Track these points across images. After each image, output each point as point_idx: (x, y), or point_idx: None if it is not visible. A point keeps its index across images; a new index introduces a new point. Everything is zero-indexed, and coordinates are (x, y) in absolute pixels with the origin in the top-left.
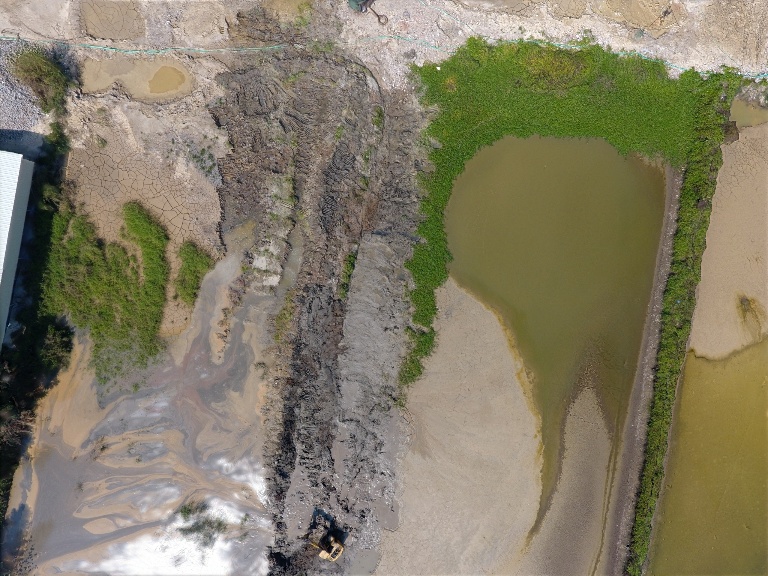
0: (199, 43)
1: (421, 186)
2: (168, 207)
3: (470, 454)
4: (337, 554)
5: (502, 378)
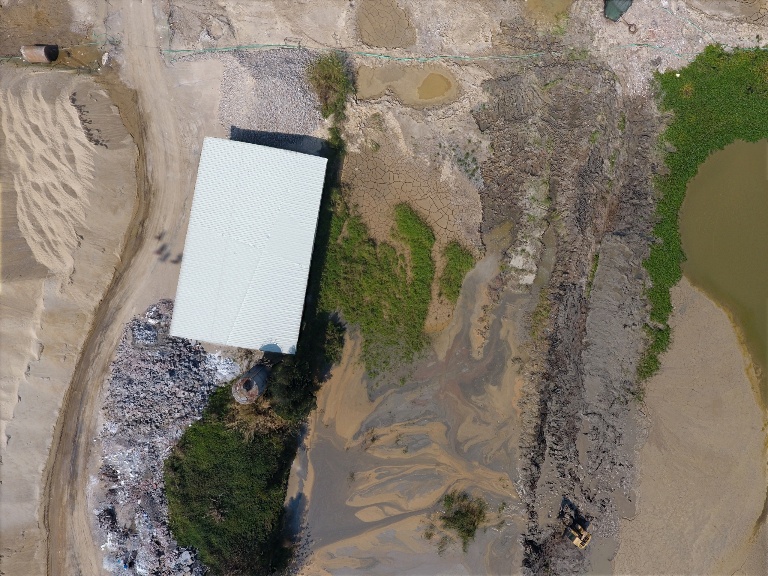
0: (465, 51)
1: (657, 188)
2: (434, 208)
3: (702, 446)
4: (586, 542)
5: (732, 373)
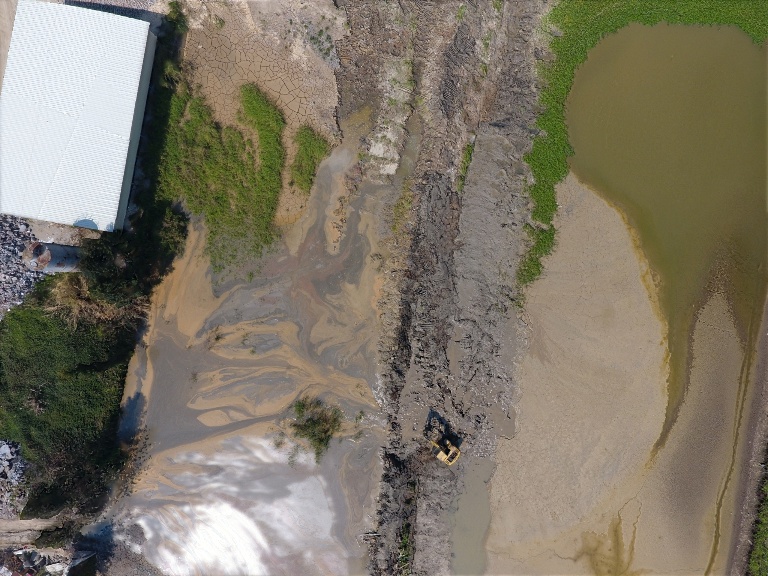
0: None
1: (541, 76)
2: (285, 90)
3: (591, 360)
4: (454, 458)
5: (626, 280)
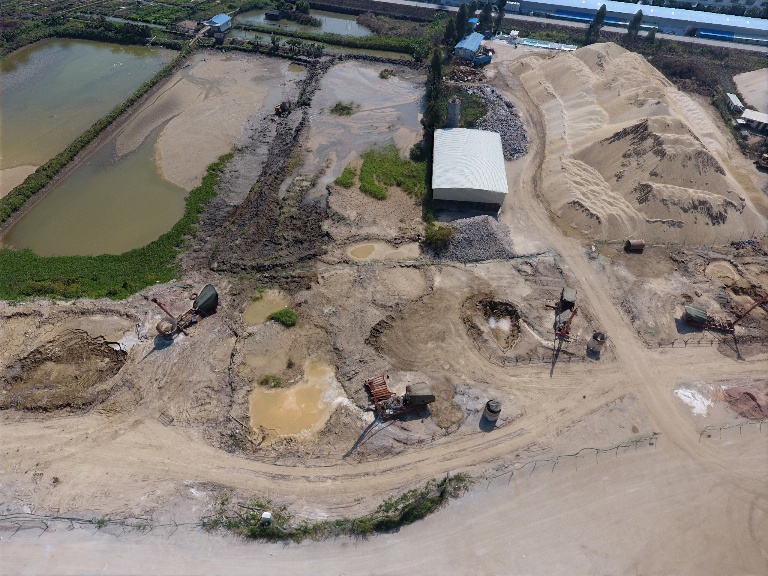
0: None
1: None
2: None
3: (201, 135)
4: None
5: (172, 158)
